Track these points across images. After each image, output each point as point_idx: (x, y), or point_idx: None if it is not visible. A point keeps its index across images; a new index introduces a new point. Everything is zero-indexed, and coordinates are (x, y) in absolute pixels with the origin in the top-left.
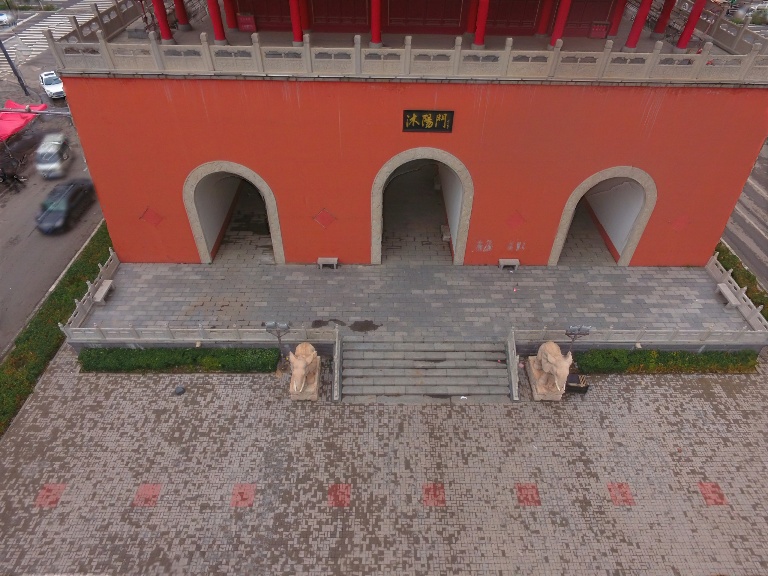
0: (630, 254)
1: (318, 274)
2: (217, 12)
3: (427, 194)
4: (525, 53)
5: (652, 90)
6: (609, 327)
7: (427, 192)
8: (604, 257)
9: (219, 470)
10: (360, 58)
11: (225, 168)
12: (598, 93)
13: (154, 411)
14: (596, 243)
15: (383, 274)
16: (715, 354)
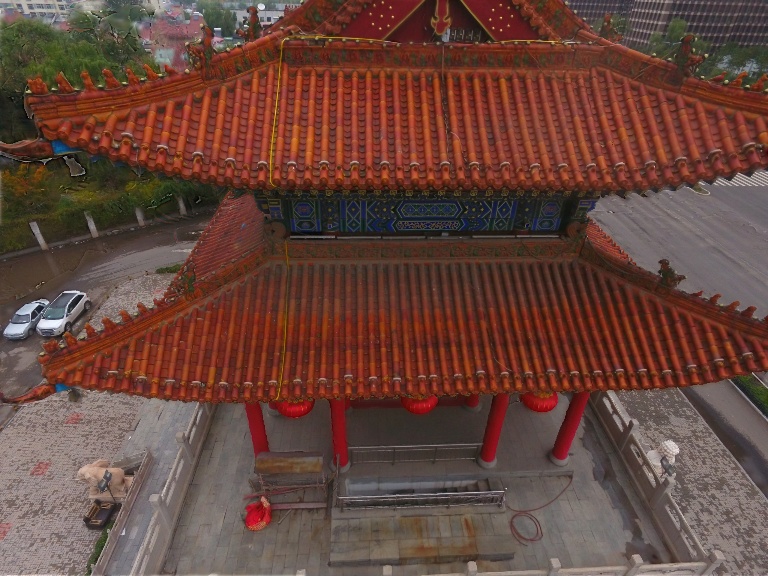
0: None
1: None
2: None
3: None
4: None
5: None
6: (128, 553)
7: None
8: None
9: None
10: None
11: None
12: None
13: None
14: None
15: None
16: None
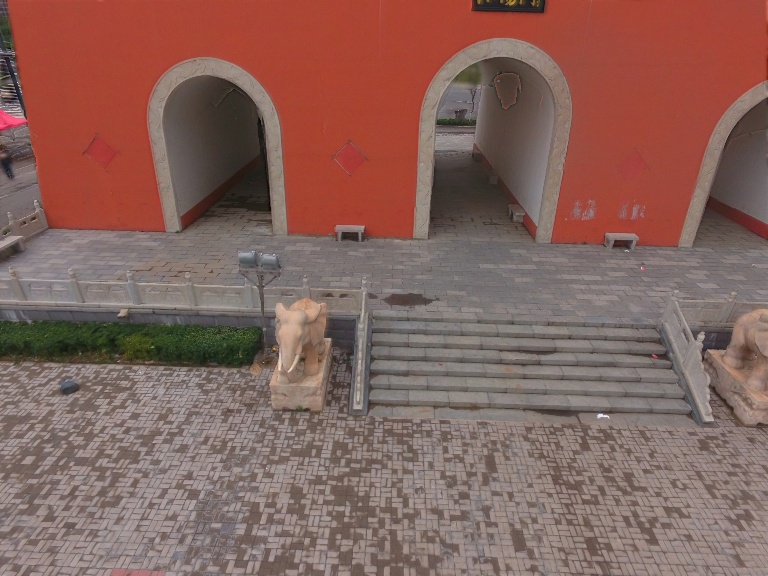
0: None
1: (334, 245)
2: None
3: (481, 187)
4: None
5: None
6: None
7: (480, 185)
8: (758, 241)
9: (88, 535)
10: None
11: (211, 70)
12: None
13: (5, 418)
14: (736, 229)
15: (432, 248)
16: None
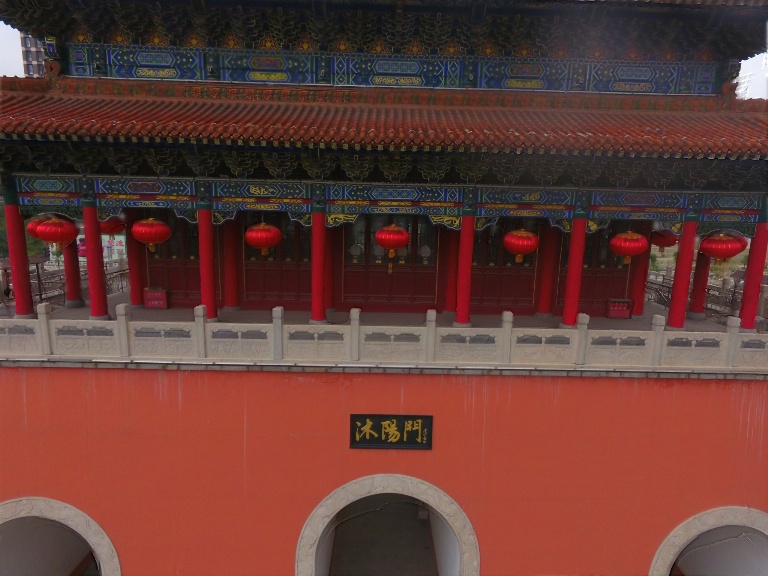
0: None
1: None
2: (99, 282)
3: (408, 527)
4: (534, 332)
5: (743, 384)
6: None
7: (408, 524)
8: None
9: None
10: (281, 338)
11: (39, 510)
12: (659, 389)
13: None
14: None
15: None
16: None
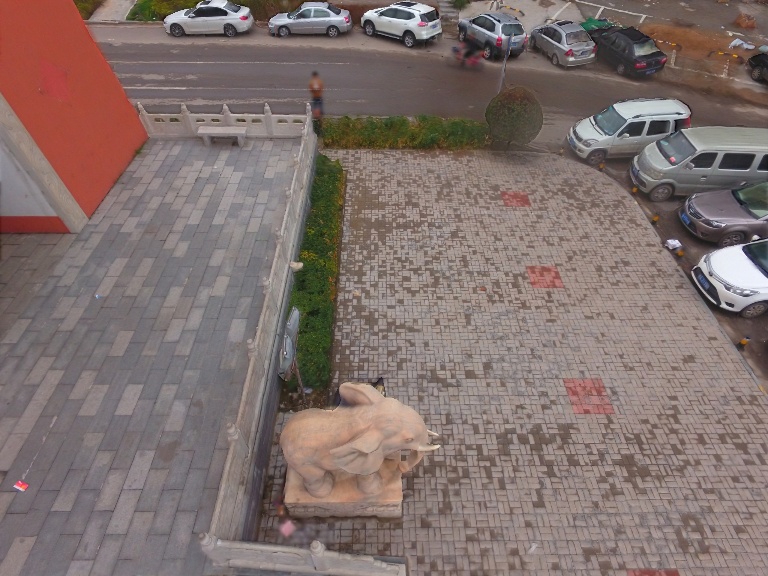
0: (66, 197)
1: None
2: None
3: None
4: None
5: None
6: (240, 296)
7: None
8: (36, 247)
9: None
10: None
11: None
12: None
13: None
14: None
15: None
16: (319, 190)
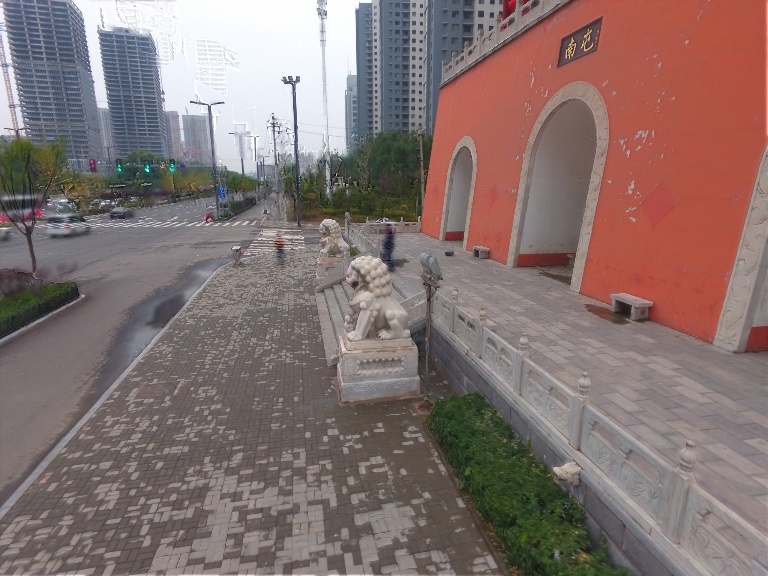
0: None
1: None
2: None
3: None
4: None
5: None
6: None
7: None
8: None
9: None
10: None
11: None
12: None
13: None
14: None
15: None
16: None
